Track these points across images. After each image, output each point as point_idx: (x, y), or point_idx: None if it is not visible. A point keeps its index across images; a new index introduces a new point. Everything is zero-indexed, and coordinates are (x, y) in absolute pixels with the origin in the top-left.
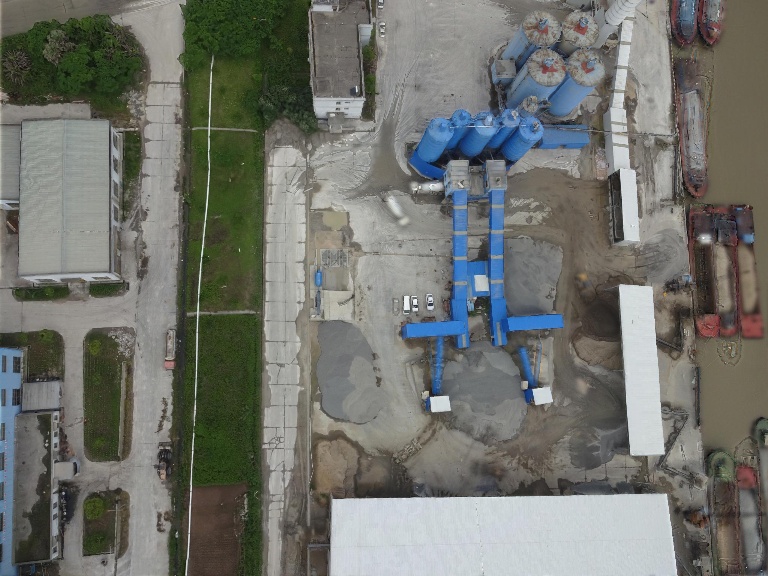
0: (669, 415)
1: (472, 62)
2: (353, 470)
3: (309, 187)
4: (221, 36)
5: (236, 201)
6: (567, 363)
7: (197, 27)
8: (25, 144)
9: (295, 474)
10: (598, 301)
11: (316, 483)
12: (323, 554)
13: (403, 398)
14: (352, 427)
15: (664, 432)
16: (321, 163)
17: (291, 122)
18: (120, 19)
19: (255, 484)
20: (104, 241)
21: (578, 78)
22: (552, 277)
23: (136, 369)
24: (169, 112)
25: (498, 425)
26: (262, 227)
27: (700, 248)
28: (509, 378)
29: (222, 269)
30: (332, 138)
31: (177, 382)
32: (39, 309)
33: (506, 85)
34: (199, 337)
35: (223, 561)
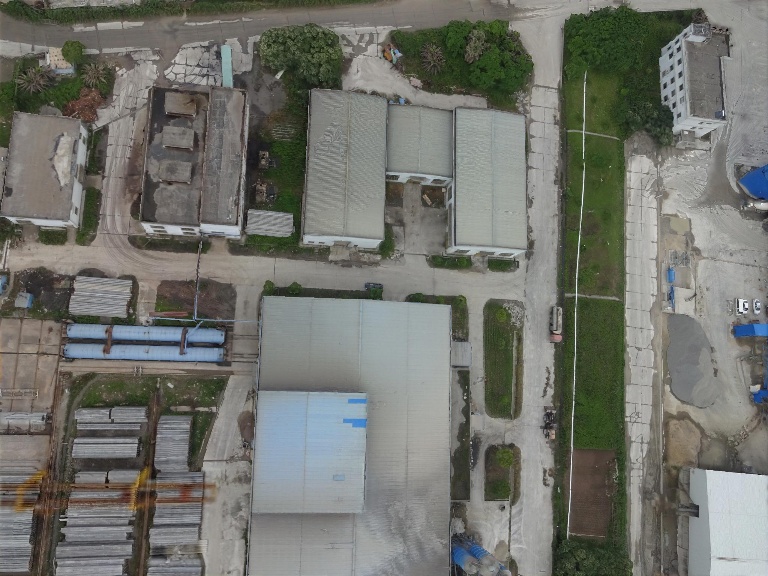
0: None
1: None
2: (698, 448)
3: (660, 194)
4: (604, 52)
5: (605, 199)
6: None
7: (583, 42)
8: (460, 128)
9: (651, 446)
10: None
11: (668, 456)
12: (674, 520)
13: (735, 389)
14: (695, 410)
15: None
16: (669, 174)
17: (648, 135)
18: (510, 26)
19: (623, 452)
20: (523, 222)
21: None
22: None
23: (525, 339)
24: (549, 113)
25: None
26: (623, 225)
27: None
28: None
29: (595, 258)
30: (677, 153)
31: (558, 354)
32: (448, 276)
33: None
34: (578, 316)
35: (597, 517)
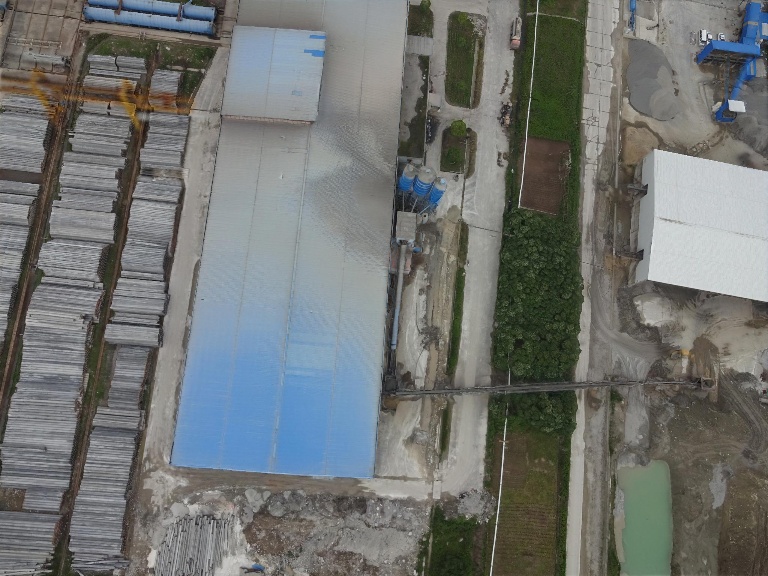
0: None
1: None
2: None
3: None
4: None
5: None
6: None
7: None
8: None
9: (607, 147)
10: None
11: (624, 156)
12: (628, 211)
13: (696, 108)
14: (654, 121)
15: None
16: None
17: None
18: None
19: (577, 145)
20: None
21: None
22: None
23: (486, 46)
24: None
25: None
26: None
27: None
28: None
29: None
30: None
31: (517, 61)
32: None
33: None
34: (537, 30)
35: (549, 197)
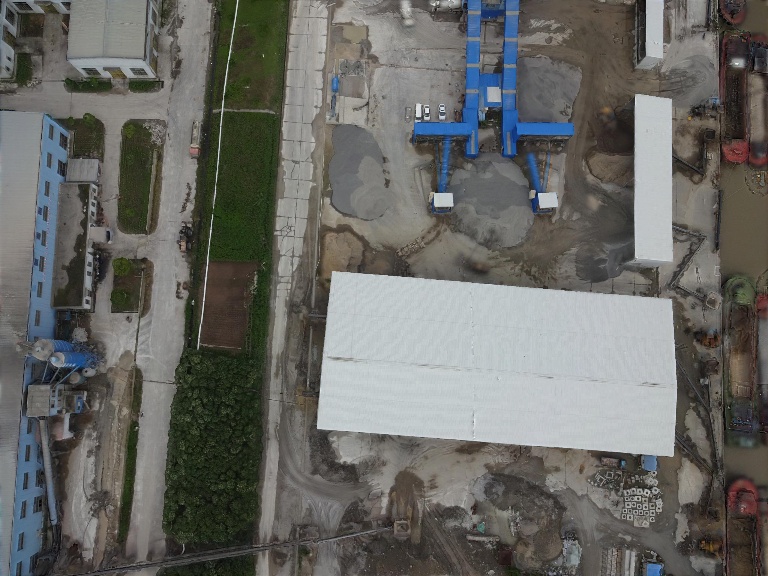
0: (685, 237)
1: None
2: (357, 260)
3: (332, 2)
4: None
5: (263, 12)
6: (579, 179)
7: None
8: None
9: (303, 260)
10: (616, 121)
11: (322, 269)
12: None
13: (410, 200)
14: (359, 222)
15: (679, 253)
16: None
17: None
18: None
19: (265, 264)
20: (141, 32)
21: None
22: (568, 94)
23: (165, 156)
24: None
25: (502, 229)
26: (286, 37)
27: (734, 78)
28: (516, 186)
29: (246, 72)
30: None
31: (201, 170)
32: (85, 100)
33: None
34: (222, 130)
35: (233, 329)
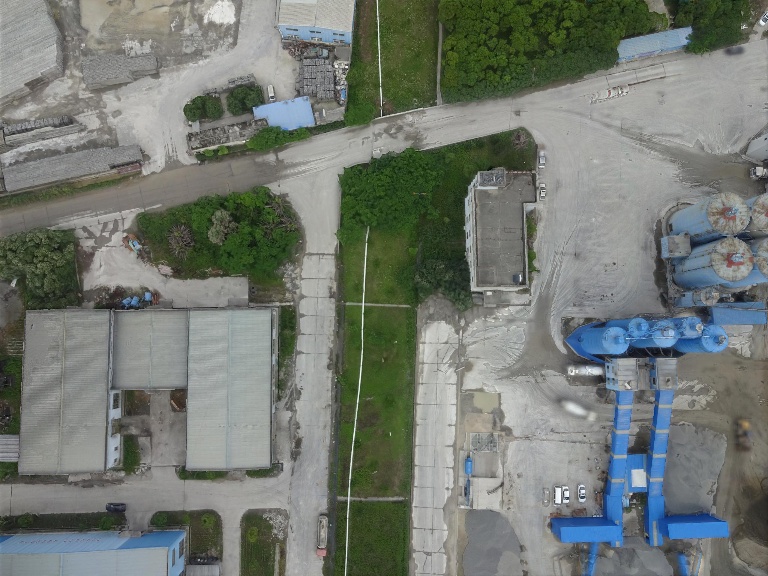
0: None
1: (637, 226)
2: None
3: (461, 366)
4: (380, 212)
5: (388, 382)
6: (725, 564)
7: (355, 201)
8: (193, 334)
9: None
10: (763, 497)
11: None
12: None
13: None
14: None
15: None
16: (474, 340)
17: (445, 297)
18: (277, 186)
19: None
20: (266, 435)
21: (767, 271)
22: (715, 471)
23: (289, 552)
24: (324, 285)
25: None
26: (413, 408)
27: None
28: None
29: (373, 454)
30: (486, 312)
31: (327, 567)
32: (200, 488)
33: (676, 259)
34: (349, 524)
35: None
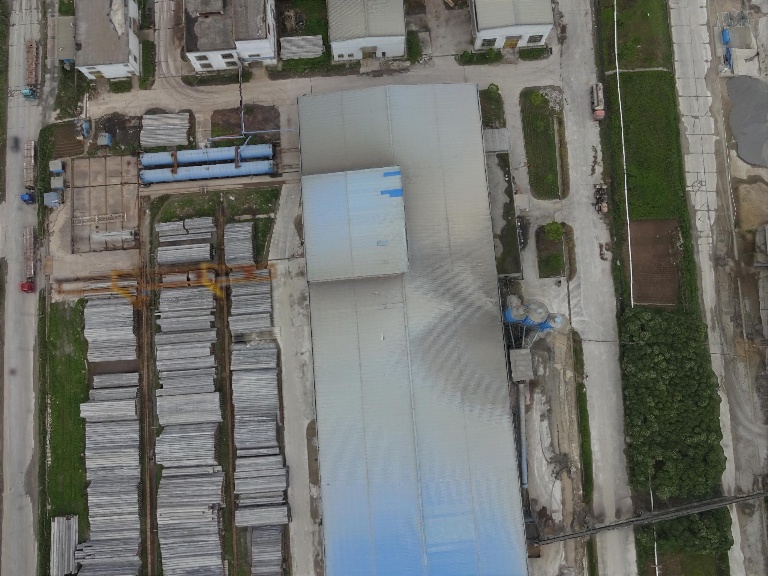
0: None
1: None
2: None
3: None
4: None
5: None
6: None
7: None
8: None
9: (719, 213)
10: None
11: (740, 221)
12: (754, 284)
13: None
14: None
15: None
16: None
17: None
18: None
19: (686, 219)
20: None
21: None
22: None
23: (566, 121)
24: None
25: None
26: None
27: None
28: None
29: (635, 31)
30: None
31: (604, 132)
32: (478, 72)
33: None
34: (621, 91)
35: (663, 286)
